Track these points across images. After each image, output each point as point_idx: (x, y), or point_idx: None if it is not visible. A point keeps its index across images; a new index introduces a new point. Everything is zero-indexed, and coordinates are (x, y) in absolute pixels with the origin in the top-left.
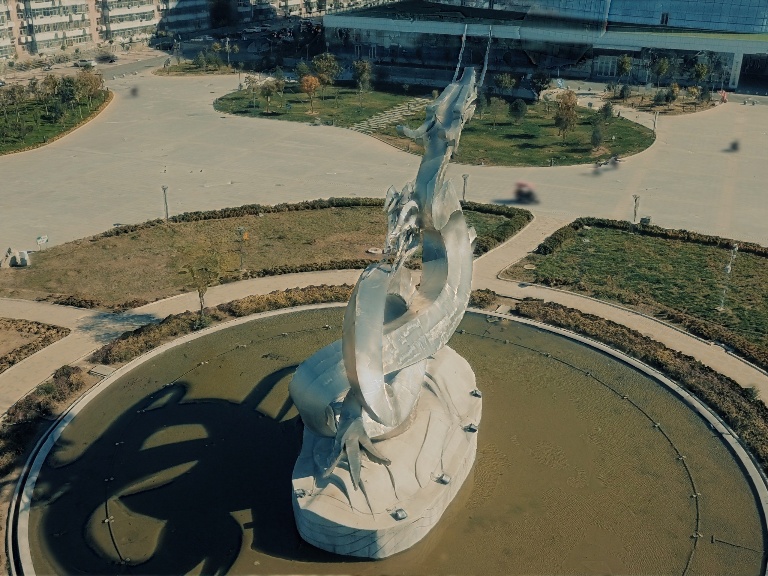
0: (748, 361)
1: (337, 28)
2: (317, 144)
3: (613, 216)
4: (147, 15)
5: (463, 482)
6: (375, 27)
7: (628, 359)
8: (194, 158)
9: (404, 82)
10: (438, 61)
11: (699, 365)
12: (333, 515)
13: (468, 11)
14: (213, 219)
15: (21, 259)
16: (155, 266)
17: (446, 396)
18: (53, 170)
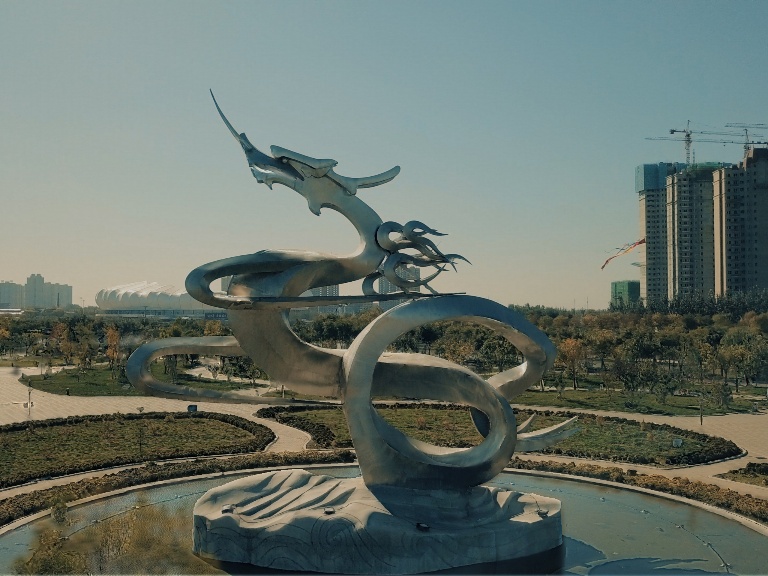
0: (75, 473)
1: None
2: None
3: None
4: None
5: None
6: None
7: None
8: None
9: None
10: None
11: None
12: None
13: None
14: None
15: None
16: None
17: None
18: None
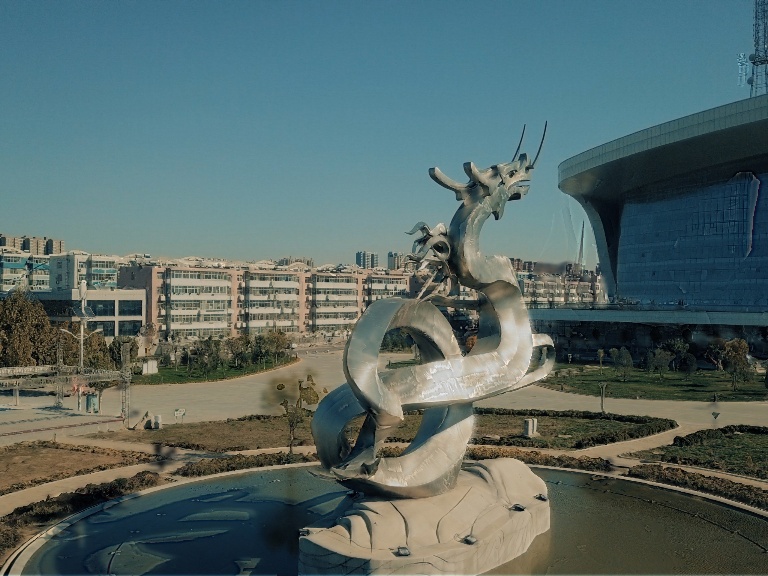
0: None
1: None
2: None
3: None
4: (351, 315)
5: (501, 564)
6: (556, 318)
7: (750, 508)
8: None
9: None
10: (615, 341)
11: None
12: (327, 543)
13: None
14: None
15: (155, 423)
16: (271, 435)
17: (500, 487)
18: (221, 391)
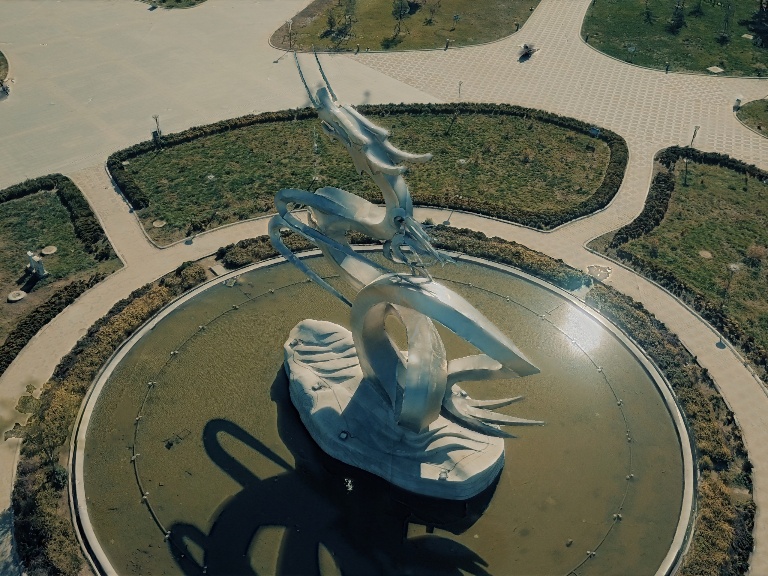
0: None
1: None
2: None
3: (118, 141)
4: None
5: None
6: None
7: None
8: None
9: None
10: None
11: None
12: (484, 464)
13: None
14: None
15: None
16: None
17: None
18: None
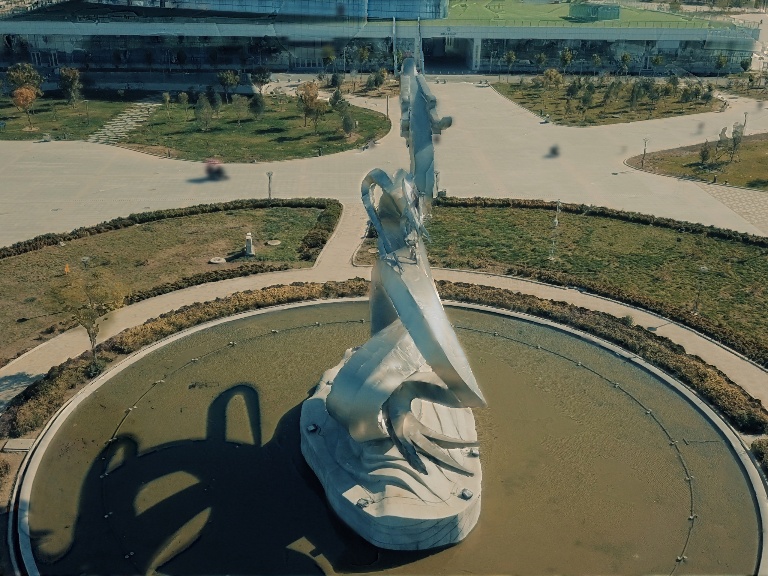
0: (603, 297)
1: (4, 35)
2: (64, 161)
3: None
4: None
5: None
6: (52, 31)
7: (517, 314)
8: None
9: (111, 88)
10: (139, 63)
11: (574, 307)
12: (413, 513)
13: (138, 10)
14: (9, 257)
15: None
16: None
17: None
18: None
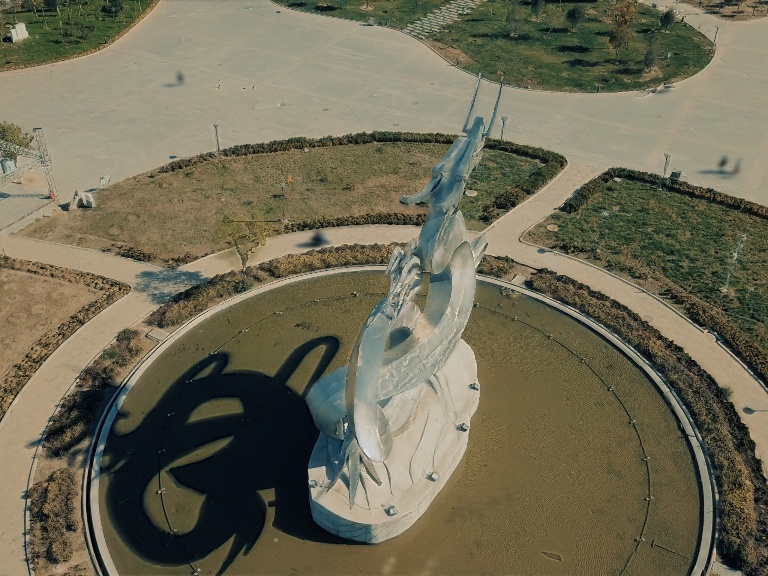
0: (734, 354)
1: None
2: (368, 53)
3: (646, 164)
4: None
5: (452, 472)
6: None
7: (622, 346)
8: (247, 69)
9: None
10: None
11: (686, 358)
12: (337, 509)
13: None
14: (261, 153)
15: (87, 201)
16: (206, 212)
17: (446, 392)
18: (114, 82)
